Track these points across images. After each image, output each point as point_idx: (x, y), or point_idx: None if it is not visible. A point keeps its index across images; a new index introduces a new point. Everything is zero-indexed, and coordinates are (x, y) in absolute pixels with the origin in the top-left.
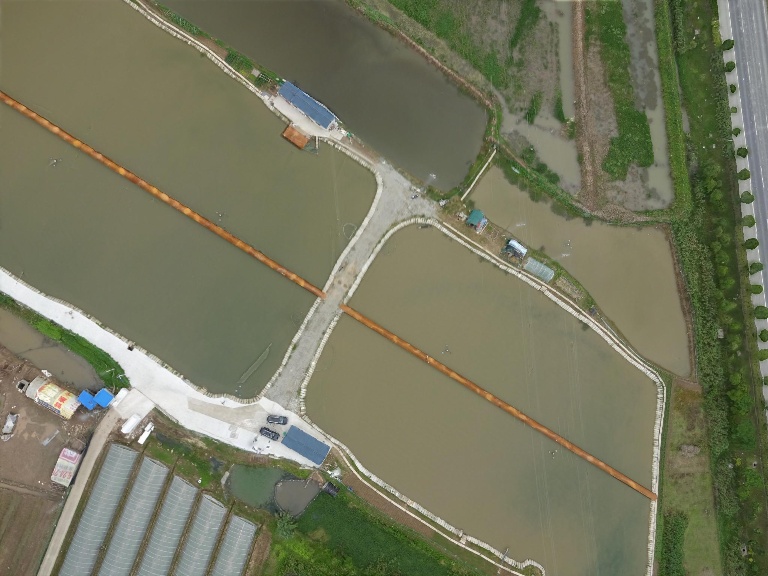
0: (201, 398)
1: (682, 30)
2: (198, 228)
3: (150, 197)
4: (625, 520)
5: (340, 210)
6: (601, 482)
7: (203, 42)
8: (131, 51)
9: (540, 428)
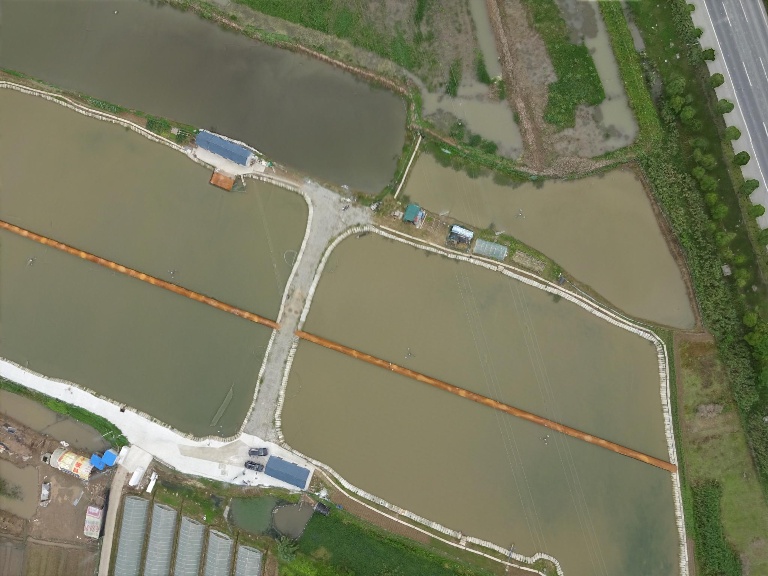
0: (189, 443)
1: None
2: (156, 289)
3: (111, 272)
4: (643, 498)
5: (273, 241)
6: (606, 461)
7: (124, 117)
8: (69, 145)
9: (524, 415)
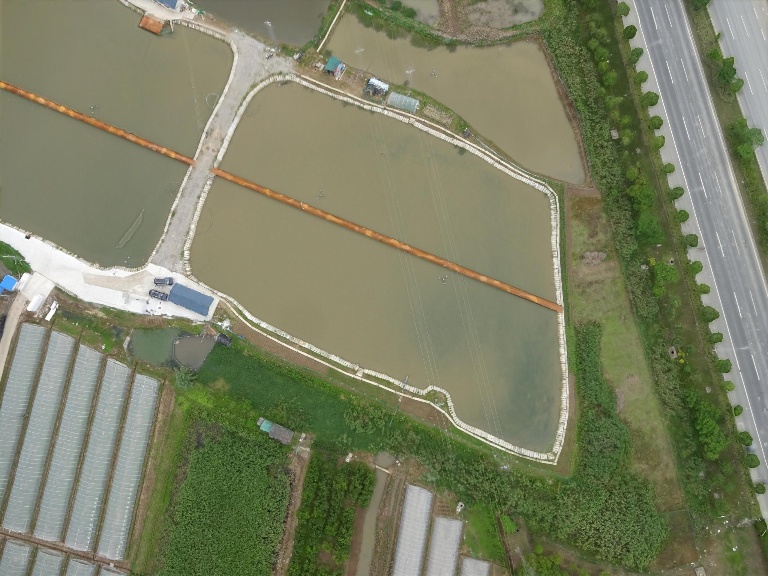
0: (94, 272)
1: None
2: (74, 123)
3: (29, 103)
4: (531, 336)
5: (195, 79)
6: (499, 301)
7: None
8: None
9: (426, 256)
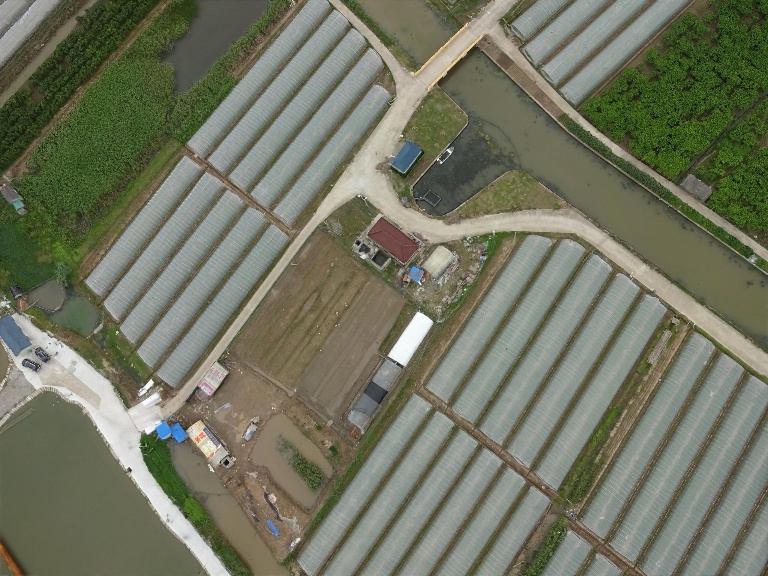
0: (88, 405)
1: None
2: (32, 575)
3: None
4: None
5: None
6: None
7: None
8: None
9: None
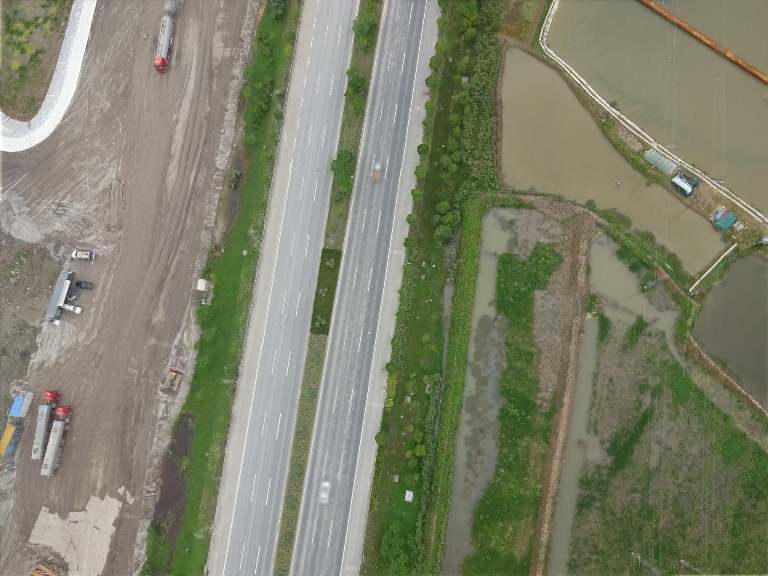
0: None
1: (433, 401)
2: None
3: None
4: None
5: None
6: None
7: None
8: None
9: (679, 22)
